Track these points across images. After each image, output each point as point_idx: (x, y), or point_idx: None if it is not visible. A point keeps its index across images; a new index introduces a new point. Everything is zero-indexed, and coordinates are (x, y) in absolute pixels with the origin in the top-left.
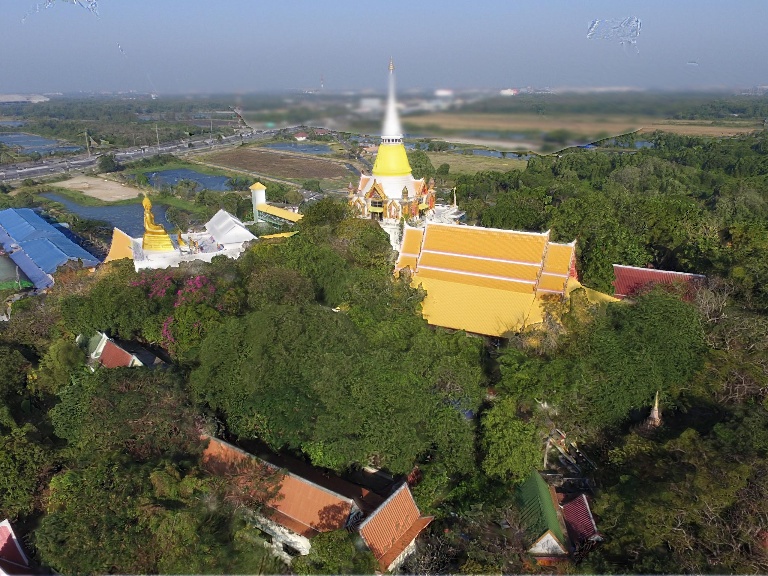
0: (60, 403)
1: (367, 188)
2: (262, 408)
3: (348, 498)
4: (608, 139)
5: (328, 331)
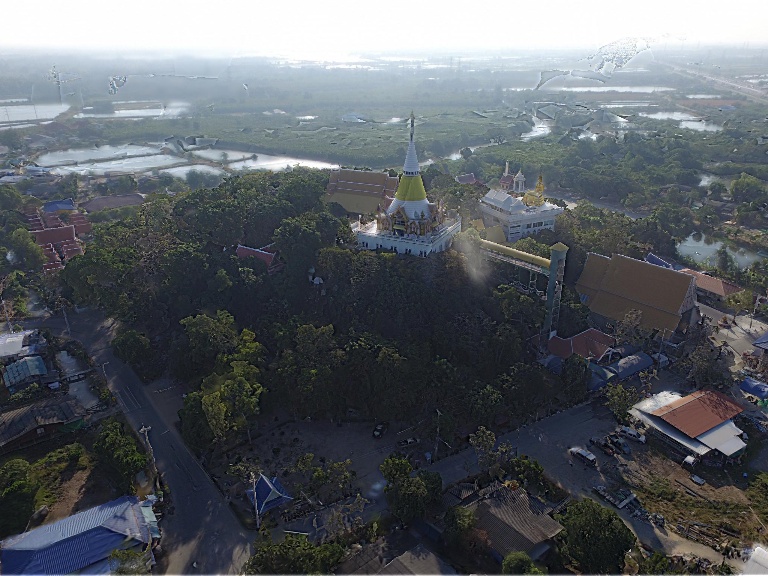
0: None
1: None
2: None
3: None
4: None
5: None
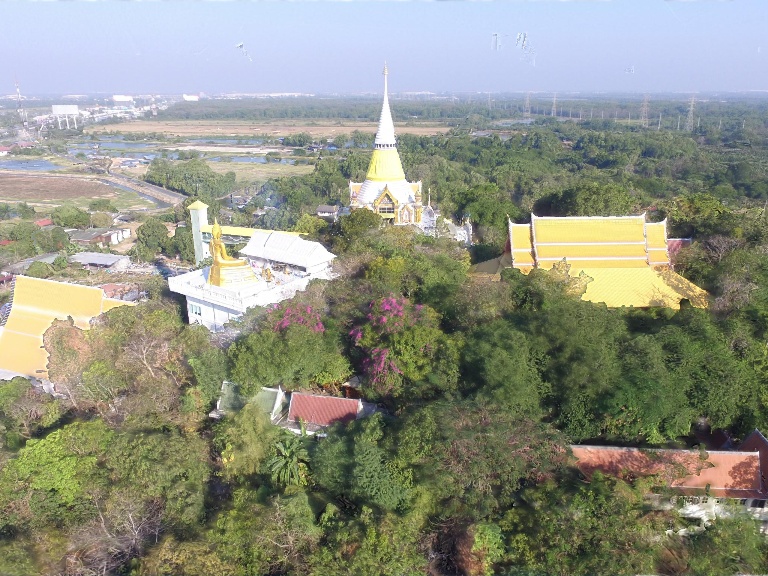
0: (356, 468)
1: (370, 195)
2: (628, 401)
3: (753, 452)
4: (347, 141)
5: (608, 322)
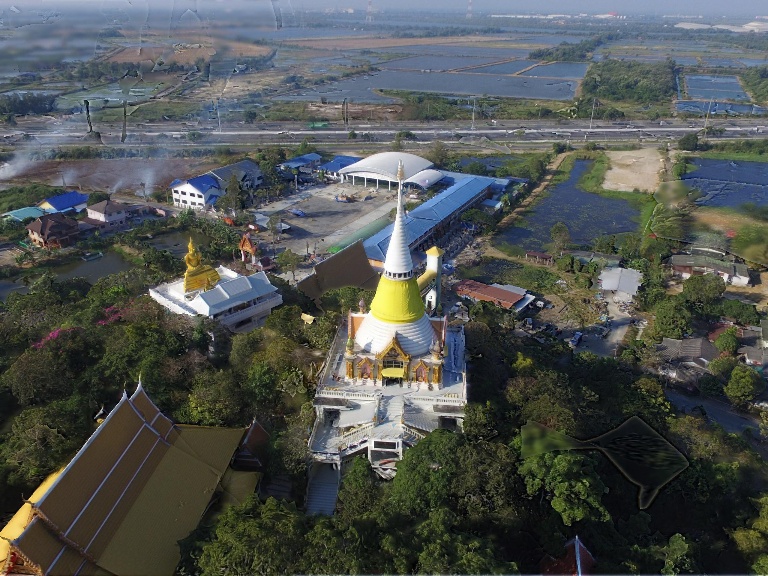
0: None
1: None
2: None
3: None
4: None
5: None
